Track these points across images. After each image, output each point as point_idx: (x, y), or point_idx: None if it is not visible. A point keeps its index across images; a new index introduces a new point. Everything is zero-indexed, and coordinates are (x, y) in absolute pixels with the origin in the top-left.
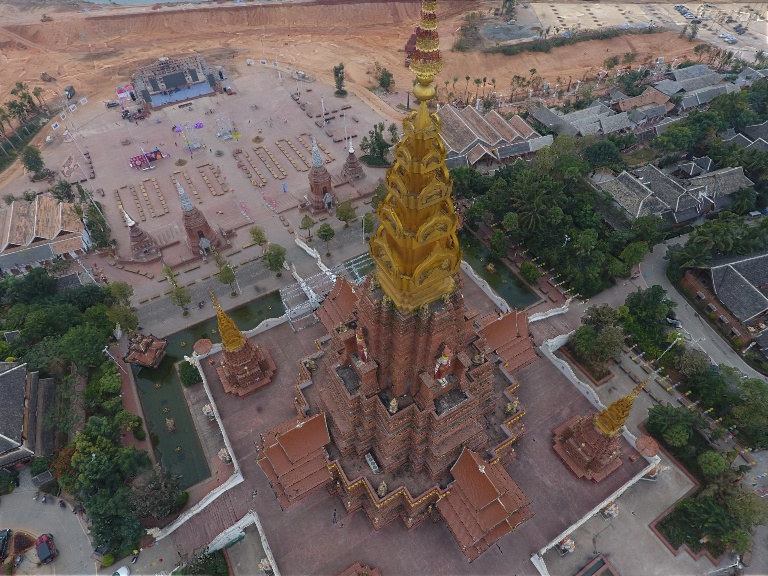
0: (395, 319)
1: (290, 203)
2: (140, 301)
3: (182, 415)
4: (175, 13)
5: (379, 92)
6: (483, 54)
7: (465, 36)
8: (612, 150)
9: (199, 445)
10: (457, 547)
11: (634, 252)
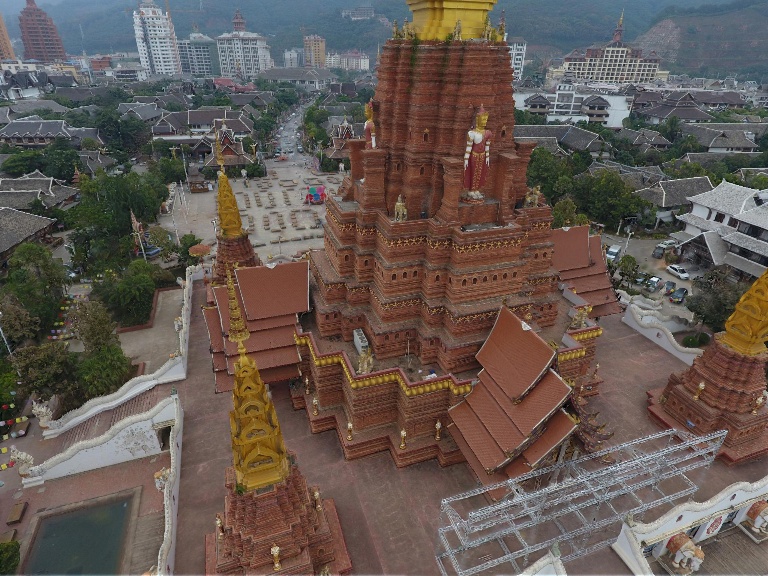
0: None
1: None
2: None
3: None
4: None
5: None
6: None
7: None
8: None
9: None
10: None
11: None
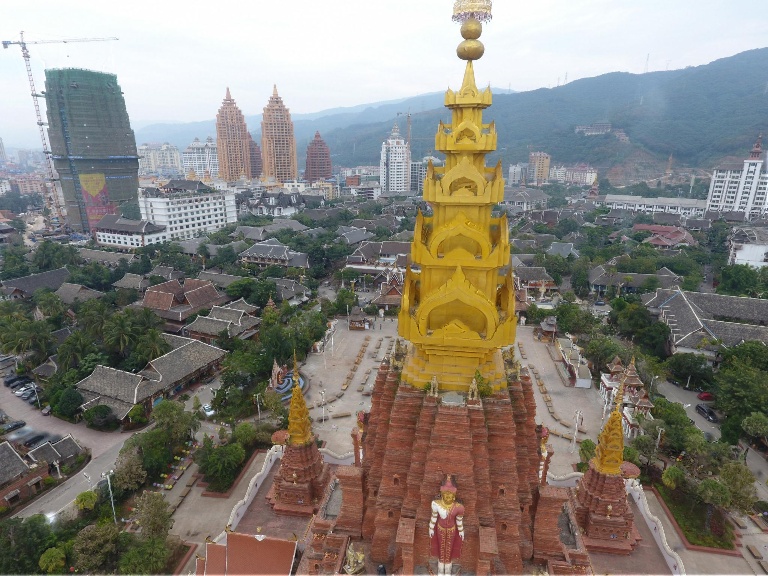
0: None
1: None
2: None
3: None
4: None
5: None
6: None
7: None
8: None
9: None
10: None
11: None
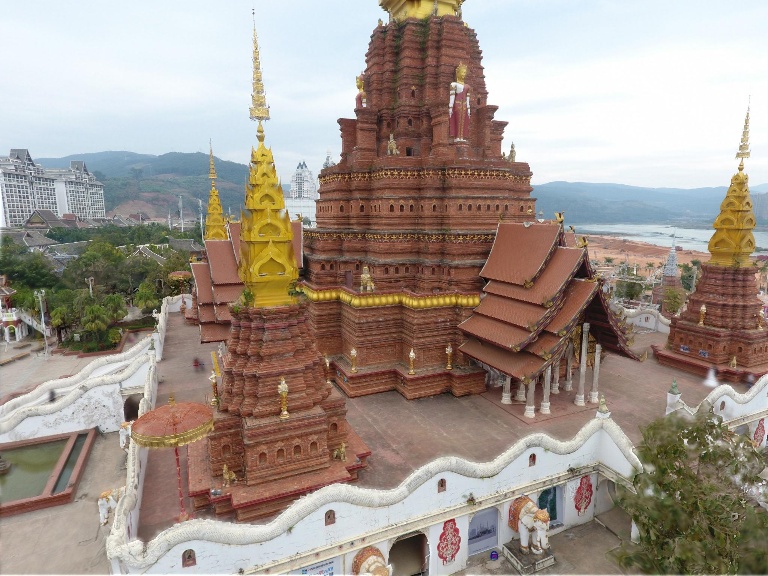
0: None
1: None
2: None
3: None
4: None
5: None
6: None
7: None
8: None
9: None
10: None
11: None
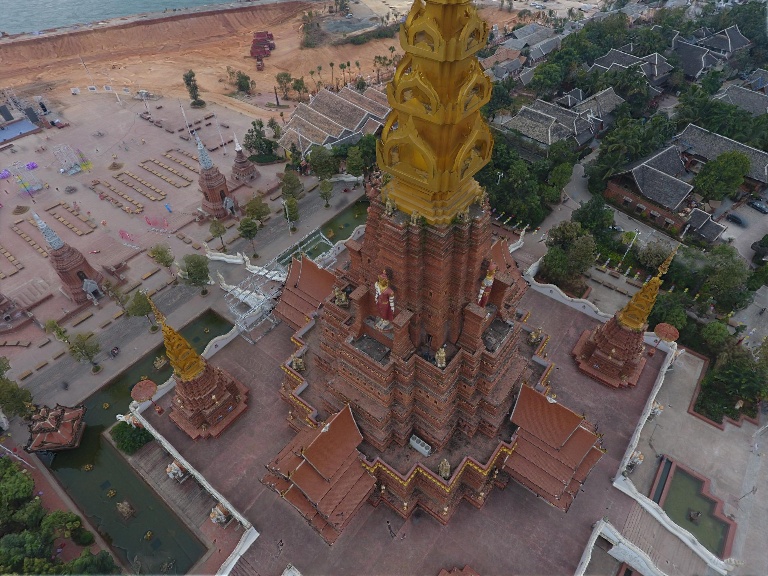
0: (429, 241)
1: (183, 220)
2: (21, 377)
3: (137, 491)
4: None
5: (240, 96)
6: (333, 47)
7: (309, 34)
8: (503, 92)
9: (176, 519)
10: (537, 505)
11: (561, 174)
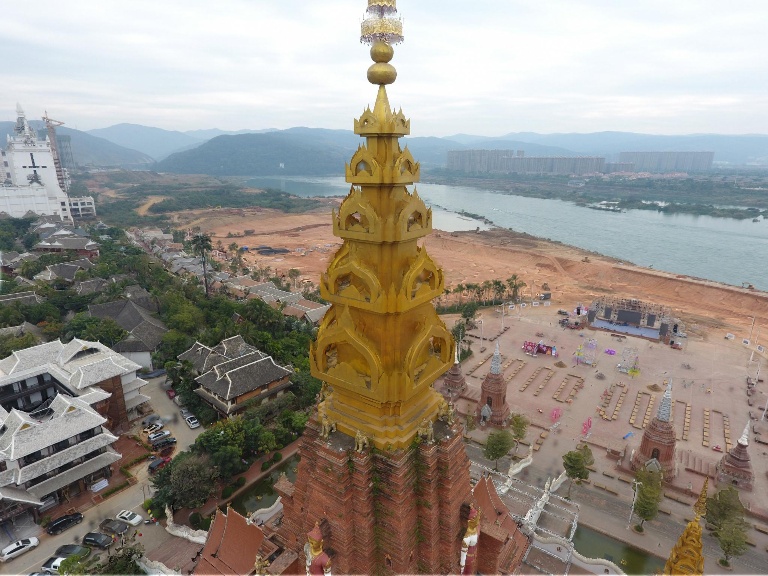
0: None
1: (610, 445)
2: None
3: None
4: (694, 285)
5: None
6: None
7: None
8: None
9: None
10: None
11: None
